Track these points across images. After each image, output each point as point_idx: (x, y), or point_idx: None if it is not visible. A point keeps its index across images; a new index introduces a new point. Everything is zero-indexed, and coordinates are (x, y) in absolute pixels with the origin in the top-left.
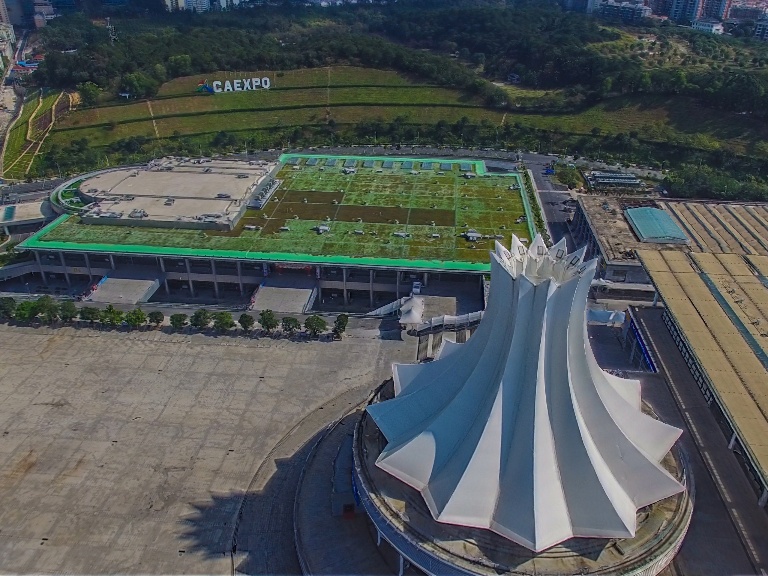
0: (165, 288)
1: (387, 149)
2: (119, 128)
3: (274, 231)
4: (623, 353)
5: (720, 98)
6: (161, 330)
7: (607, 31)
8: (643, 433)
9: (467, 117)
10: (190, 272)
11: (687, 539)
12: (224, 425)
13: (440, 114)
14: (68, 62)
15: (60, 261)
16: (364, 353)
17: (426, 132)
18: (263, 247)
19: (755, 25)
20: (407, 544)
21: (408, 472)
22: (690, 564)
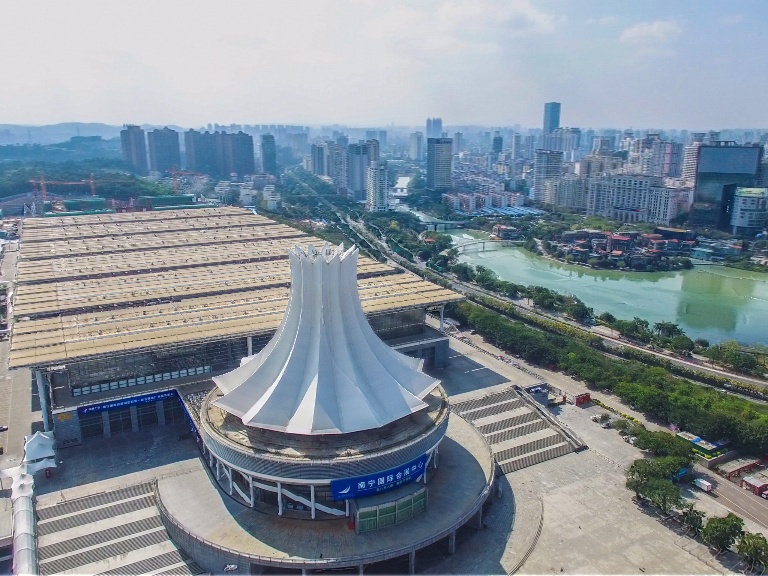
0: None
1: None
2: None
3: None
4: (90, 443)
5: None
6: None
7: None
8: None
9: None
10: None
11: None
12: None
13: None
14: None
15: None
16: None
17: None
18: None
19: None
20: None
21: None
22: None
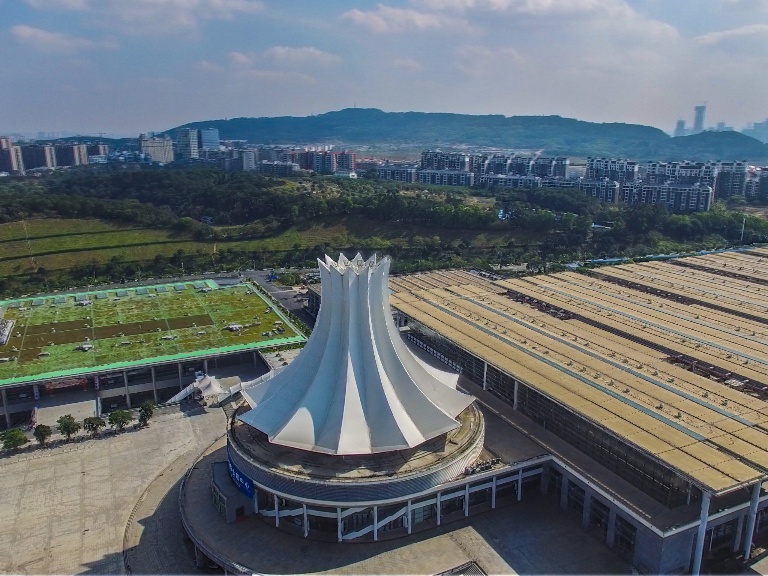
0: None
1: (111, 285)
2: None
3: (33, 358)
4: None
5: (379, 212)
6: None
7: (273, 180)
8: None
9: (182, 249)
10: None
11: (486, 435)
12: (65, 516)
13: (154, 251)
14: None
15: None
16: (178, 430)
17: (145, 267)
18: (29, 371)
19: (379, 170)
20: (316, 487)
21: (297, 441)
22: (494, 445)
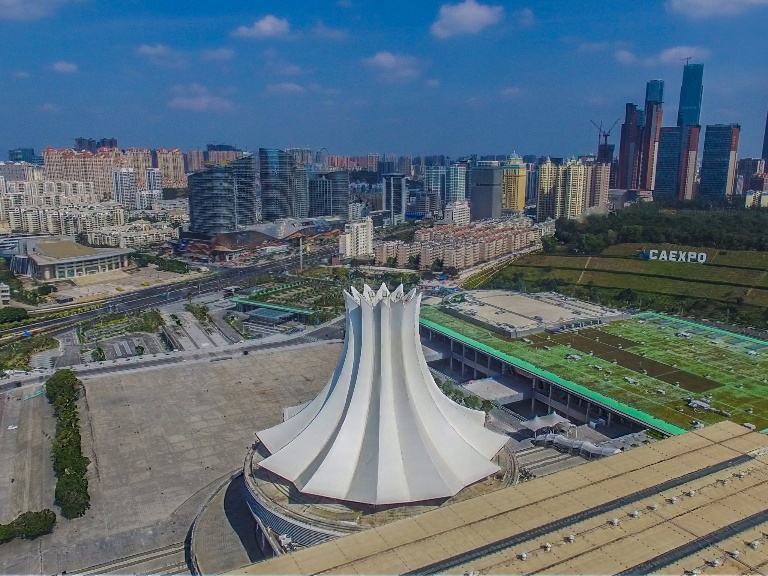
0: (450, 364)
1: None
2: (554, 272)
3: (538, 347)
4: None
5: None
6: None
7: None
8: (421, 475)
9: None
10: (464, 356)
11: None
12: None
13: None
14: None
15: None
16: None
17: None
18: (512, 352)
19: None
20: None
21: None
22: None
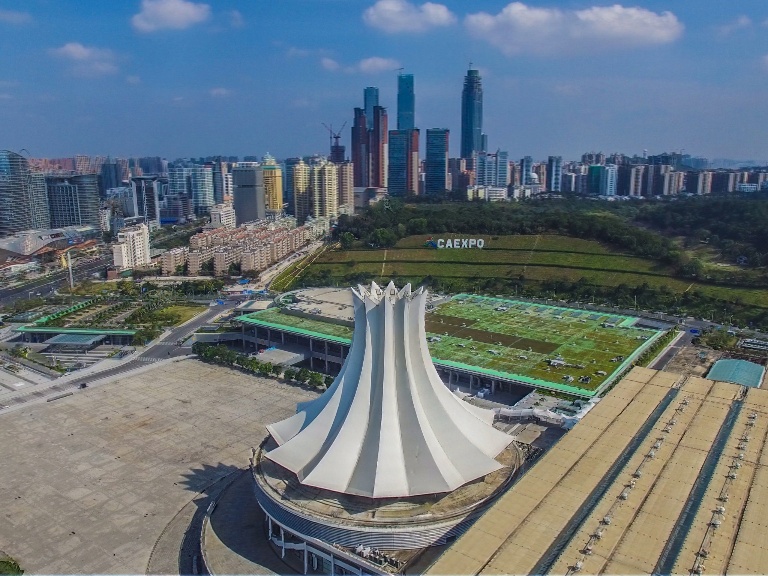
0: (310, 364)
1: (559, 302)
2: (358, 266)
3: None
4: None
5: None
6: (278, 380)
7: None
8: (464, 457)
9: None
10: (327, 354)
11: None
12: (263, 435)
13: (626, 279)
14: (351, 222)
15: (255, 333)
16: None
17: (605, 293)
18: None
19: None
20: None
21: (281, 435)
22: (437, 555)
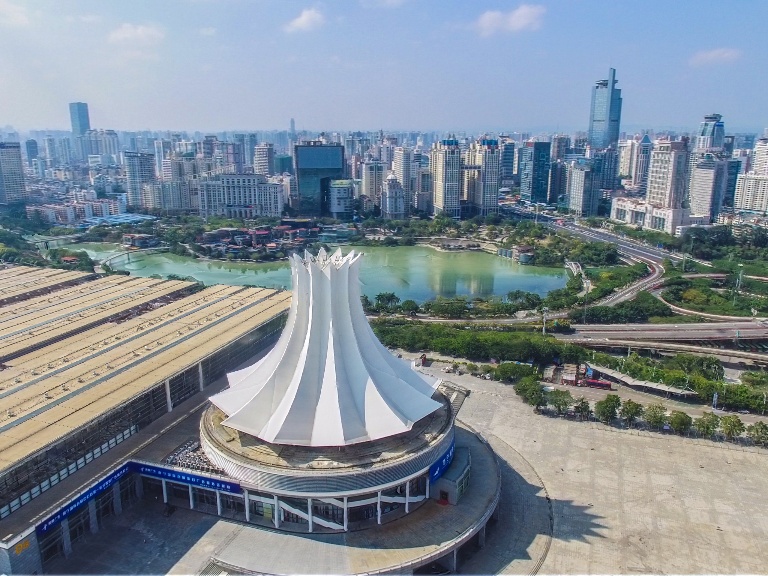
0: None
1: None
2: None
3: None
4: (55, 570)
5: None
6: None
7: None
8: None
9: None
10: None
11: None
12: None
13: None
14: None
15: None
16: None
17: None
18: None
19: None
20: None
21: None
22: None
